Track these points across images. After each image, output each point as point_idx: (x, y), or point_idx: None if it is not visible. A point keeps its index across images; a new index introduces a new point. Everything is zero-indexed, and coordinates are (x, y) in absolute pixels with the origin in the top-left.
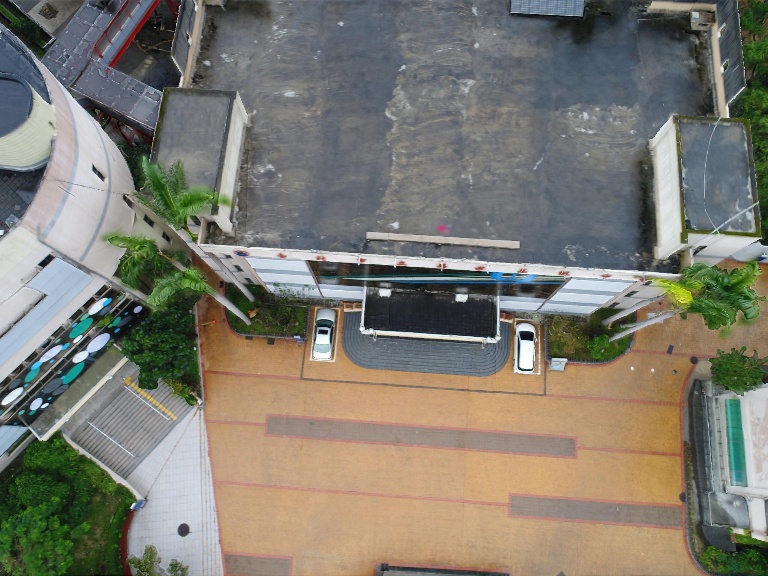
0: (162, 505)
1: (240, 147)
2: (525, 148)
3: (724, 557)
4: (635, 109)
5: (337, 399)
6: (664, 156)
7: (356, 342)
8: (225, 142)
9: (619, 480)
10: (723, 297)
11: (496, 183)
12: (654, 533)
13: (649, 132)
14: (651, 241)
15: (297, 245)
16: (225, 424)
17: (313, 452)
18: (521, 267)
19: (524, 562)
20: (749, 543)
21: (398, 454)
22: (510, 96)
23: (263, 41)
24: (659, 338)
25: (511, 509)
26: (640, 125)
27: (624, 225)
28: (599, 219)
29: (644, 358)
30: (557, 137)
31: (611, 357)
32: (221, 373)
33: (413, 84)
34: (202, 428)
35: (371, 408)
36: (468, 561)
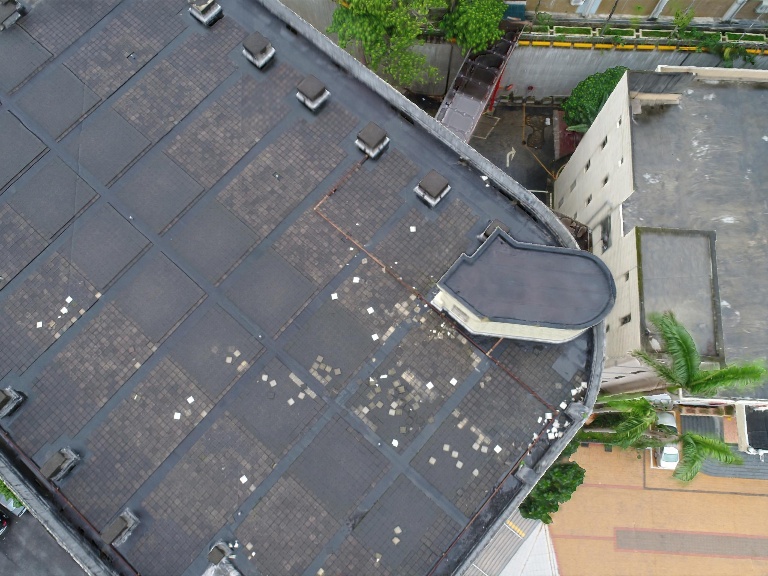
0: None
1: None
2: None
3: None
4: None
5: (685, 510)
6: None
7: None
8: (717, 290)
9: None
10: None
11: None
12: None
13: None
14: None
15: None
16: (572, 539)
17: (668, 568)
18: None
19: None
20: None
21: (757, 569)
22: None
23: (686, 159)
24: None
25: None
26: None
27: None
28: None
29: None
30: None
31: None
32: None
33: None
34: (549, 544)
35: (722, 519)
36: None
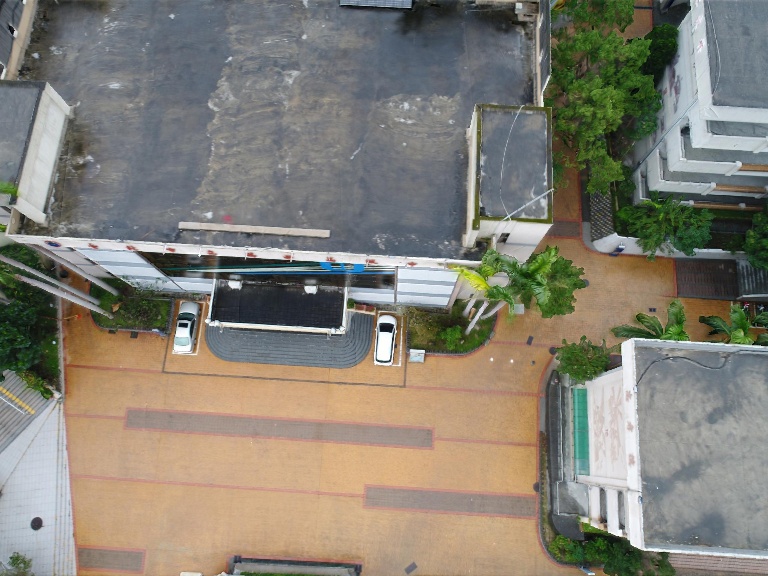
0: (16, 499)
1: (60, 138)
2: (344, 138)
3: (571, 546)
4: (456, 99)
5: (197, 392)
6: (474, 145)
7: (217, 335)
8: (30, 132)
9: (474, 470)
10: (522, 284)
11: (312, 173)
12: (507, 523)
13: (467, 122)
14: (461, 229)
15: (110, 235)
16: (84, 418)
17: (171, 445)
18: (326, 255)
19: (377, 553)
20: (594, 532)
21: (256, 446)
22: (333, 87)
23: (93, 34)
24: (519, 329)
25: (366, 500)
26: (459, 115)
27: (435, 214)
28: (411, 208)
29: (504, 349)
30: (376, 127)
31: (470, 348)
32: (83, 367)
33: (238, 75)
34: (61, 422)
35: (231, 401)
36: (321, 552)
